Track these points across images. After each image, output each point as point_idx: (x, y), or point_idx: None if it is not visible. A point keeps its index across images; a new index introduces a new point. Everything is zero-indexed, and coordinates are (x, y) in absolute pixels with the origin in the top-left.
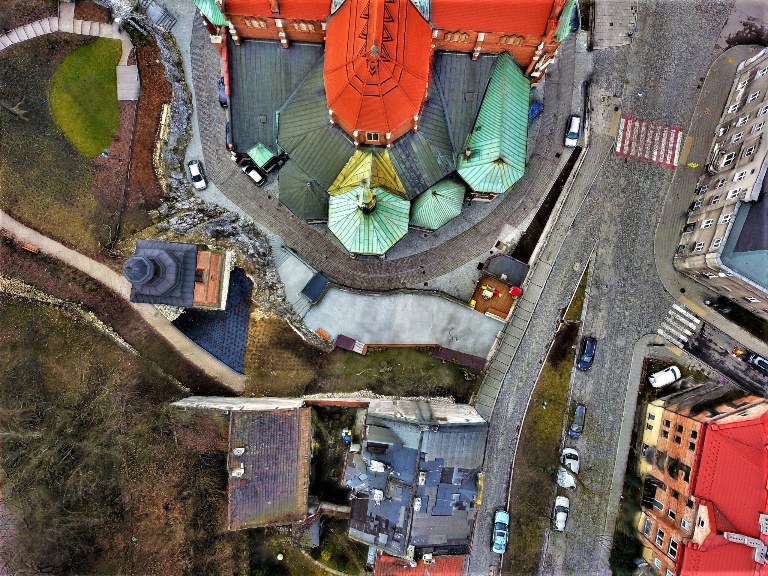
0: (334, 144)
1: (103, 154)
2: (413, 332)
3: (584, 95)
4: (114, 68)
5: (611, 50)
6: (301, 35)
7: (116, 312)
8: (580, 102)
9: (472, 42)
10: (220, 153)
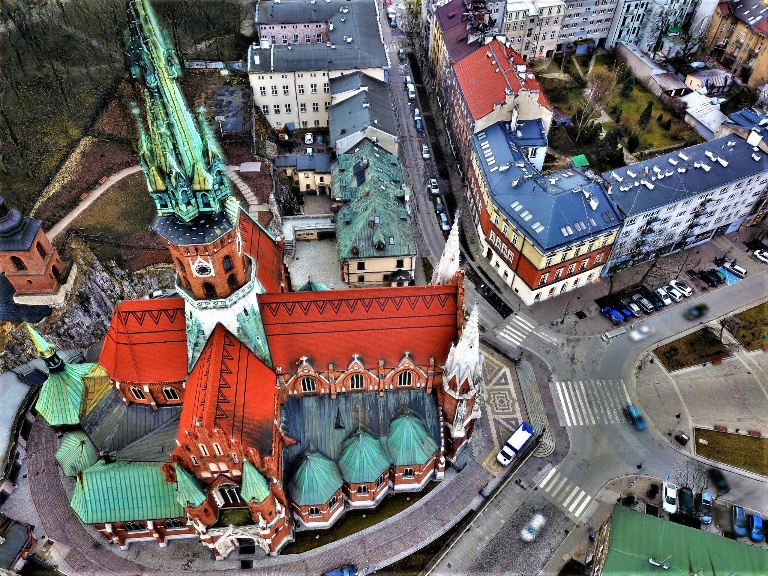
0: None
1: (150, 227)
2: None
3: None
4: None
5: None
6: None
7: None
8: None
9: None
10: None
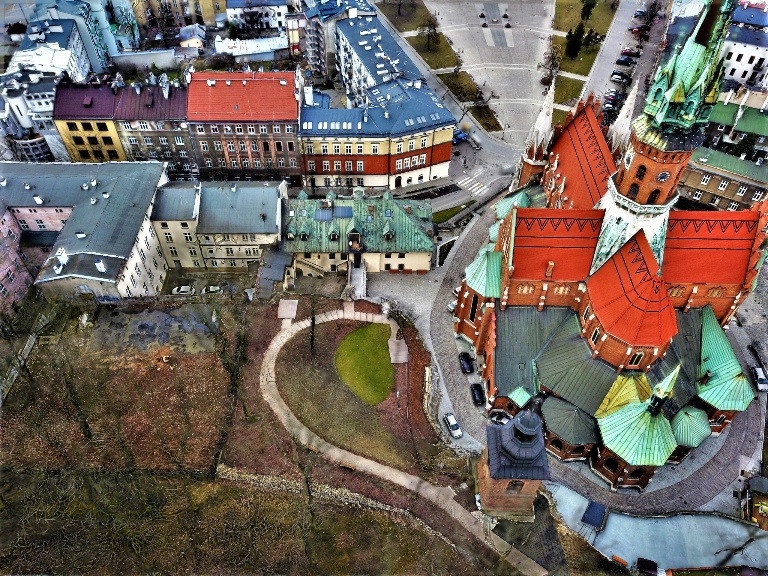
0: (596, 373)
1: (398, 393)
2: (708, 555)
3: (753, 355)
4: (386, 342)
5: (756, 326)
6: (555, 299)
7: (439, 520)
8: (752, 360)
9: (686, 296)
10: (468, 408)
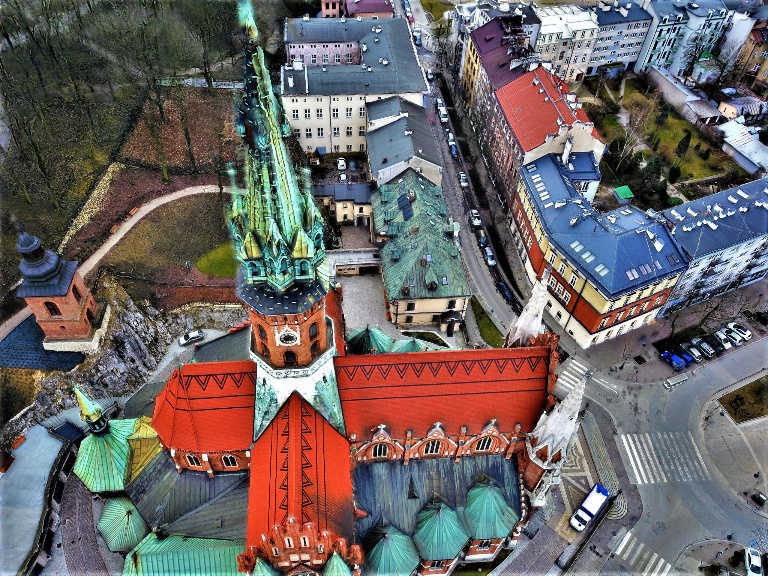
0: None
1: (187, 263)
2: None
3: None
4: None
5: None
6: None
7: None
8: None
9: None
10: None
